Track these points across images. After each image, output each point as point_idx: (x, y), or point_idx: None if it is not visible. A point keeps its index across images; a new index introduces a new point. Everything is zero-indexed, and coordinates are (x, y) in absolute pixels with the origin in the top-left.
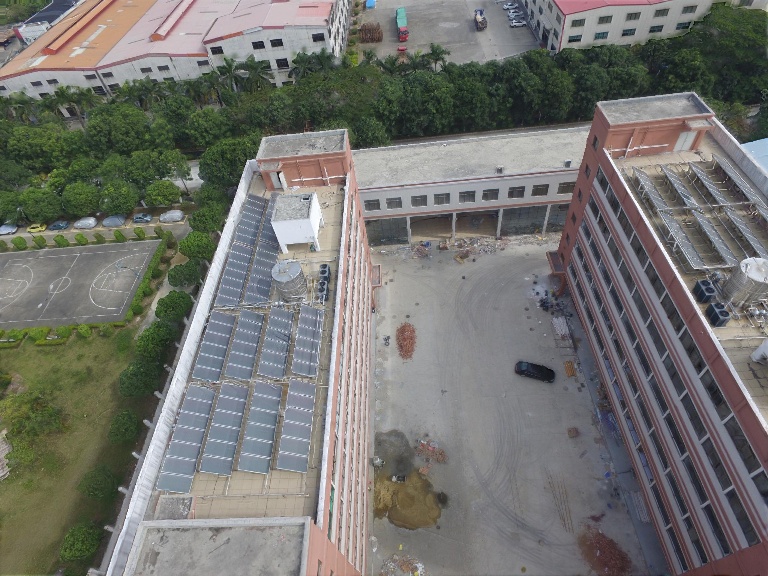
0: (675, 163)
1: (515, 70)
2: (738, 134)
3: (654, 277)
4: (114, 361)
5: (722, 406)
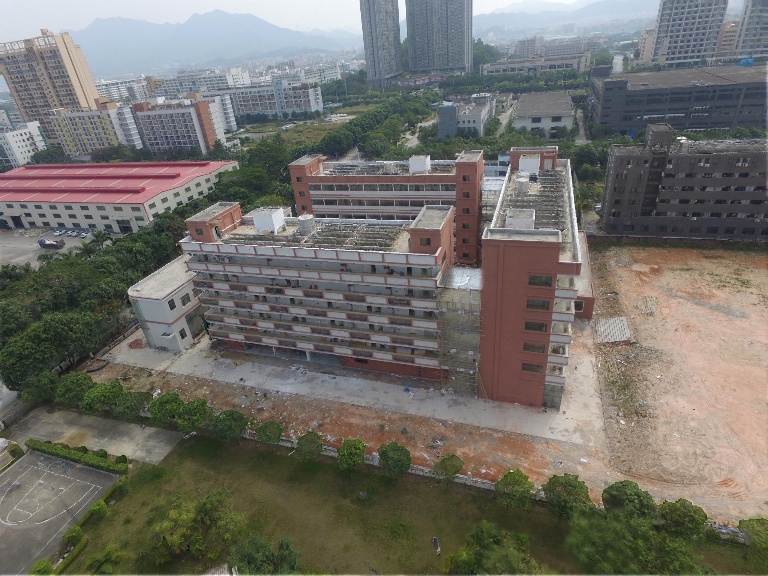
0: (328, 172)
1: (166, 223)
2: (290, 202)
3: (370, 187)
4: (167, 484)
5: (420, 188)
